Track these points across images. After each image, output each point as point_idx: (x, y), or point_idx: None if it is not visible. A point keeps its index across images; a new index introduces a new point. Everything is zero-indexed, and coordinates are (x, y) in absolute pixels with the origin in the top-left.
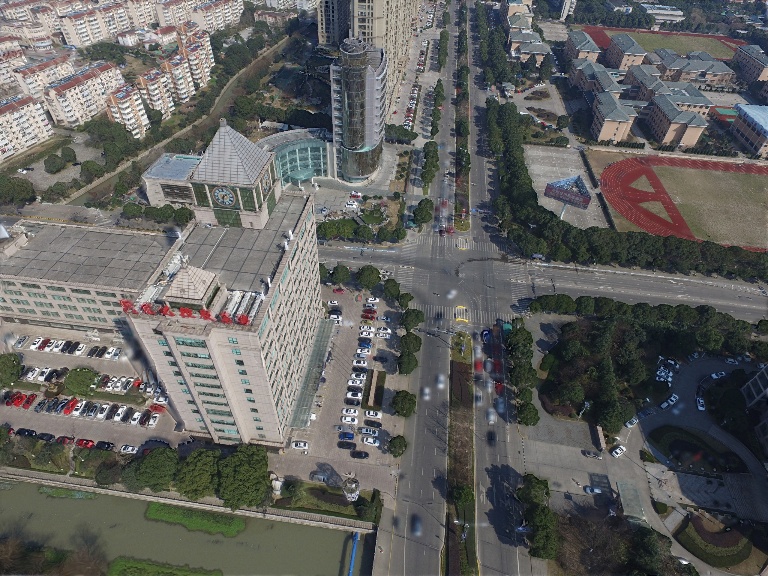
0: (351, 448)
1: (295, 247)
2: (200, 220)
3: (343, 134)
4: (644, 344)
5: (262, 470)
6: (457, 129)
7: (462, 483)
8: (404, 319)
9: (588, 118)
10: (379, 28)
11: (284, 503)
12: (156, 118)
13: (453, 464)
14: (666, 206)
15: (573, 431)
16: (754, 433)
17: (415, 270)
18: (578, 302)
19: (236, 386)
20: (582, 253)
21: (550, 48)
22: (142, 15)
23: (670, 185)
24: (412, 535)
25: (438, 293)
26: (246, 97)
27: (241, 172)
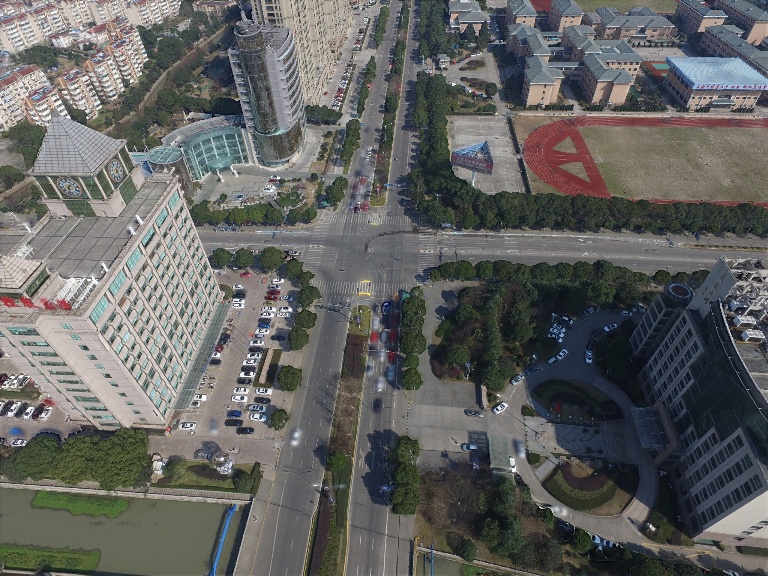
0: (237, 425)
1: (151, 232)
2: (54, 212)
3: (254, 119)
4: (537, 303)
5: (137, 452)
6: (386, 105)
7: (342, 450)
8: (299, 297)
9: (519, 84)
10: (287, 8)
11: (165, 482)
12: (79, 118)
13: (336, 433)
14: (586, 166)
15: (459, 392)
16: (636, 380)
17: (324, 249)
18: (477, 267)
19: (93, 372)
20: (489, 219)
21: (493, 16)
22: (78, 15)
23: (593, 145)
24: (287, 503)
25: (344, 269)
26: (169, 90)
27: (79, 161)
